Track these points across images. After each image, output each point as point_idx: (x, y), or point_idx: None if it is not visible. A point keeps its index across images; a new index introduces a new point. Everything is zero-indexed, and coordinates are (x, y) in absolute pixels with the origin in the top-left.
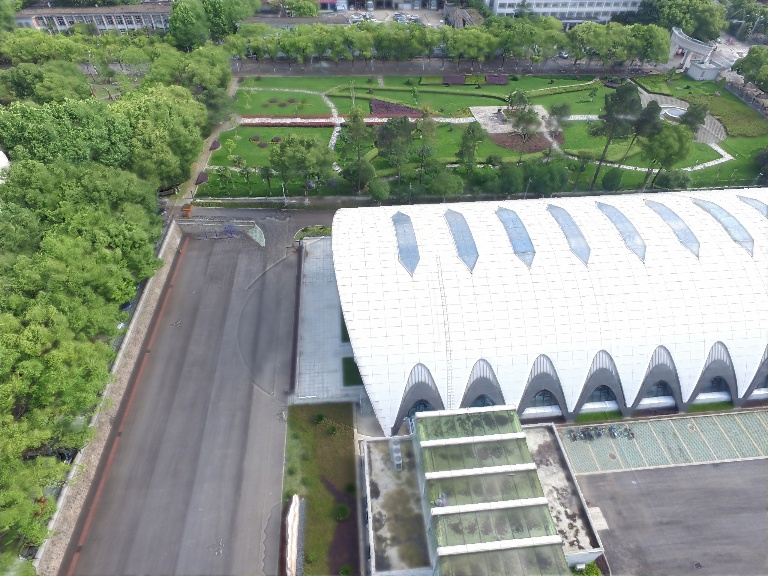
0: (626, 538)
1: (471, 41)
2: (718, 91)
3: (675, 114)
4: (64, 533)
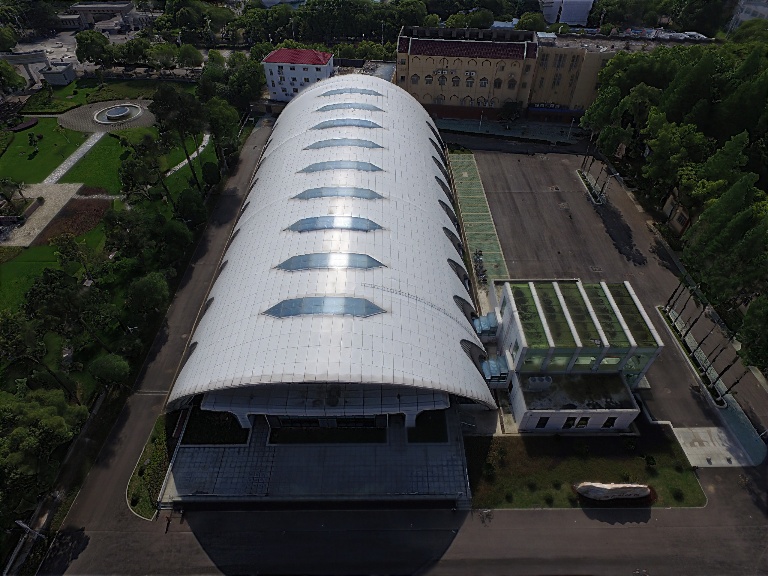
0: (551, 277)
1: None
2: (102, 82)
3: (118, 113)
4: None
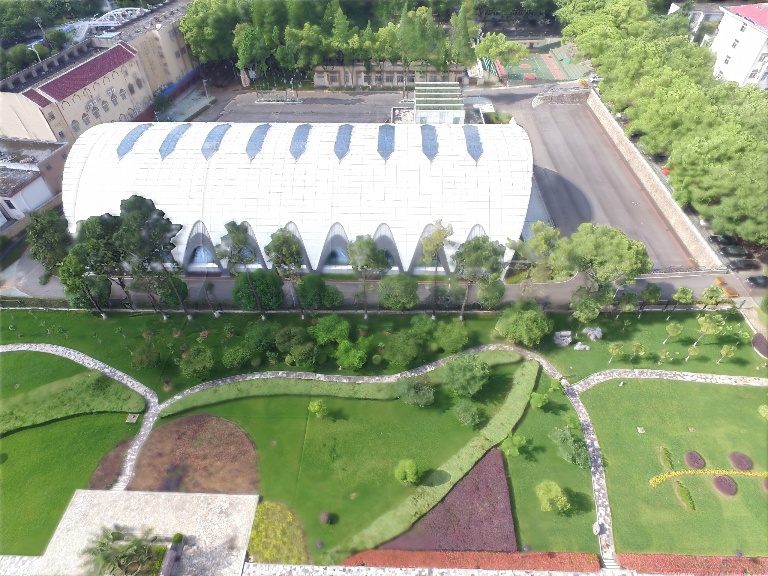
0: None
1: None
2: None
3: None
4: None
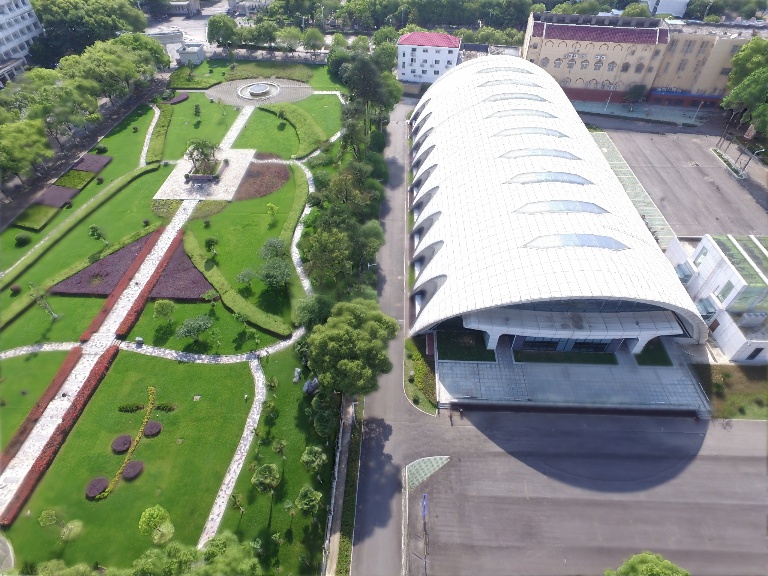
0: None
1: (22, 140)
2: (234, 62)
3: (260, 90)
4: None
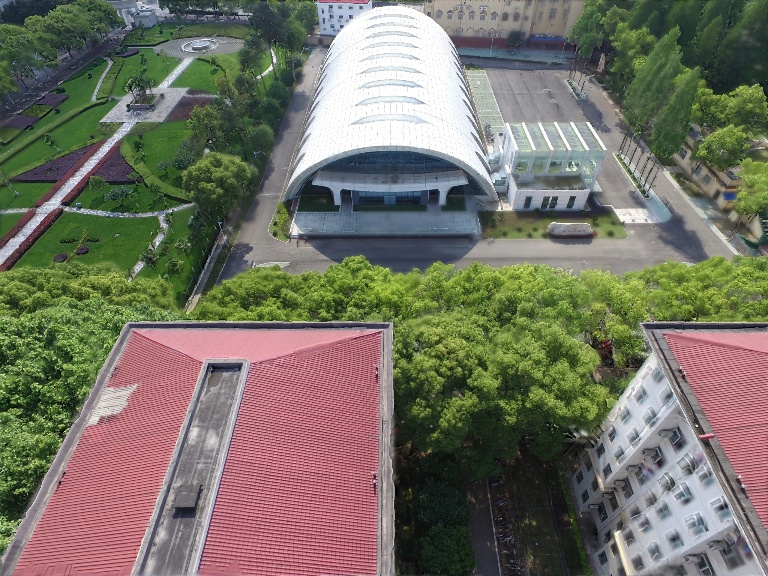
0: None
1: None
2: (181, 24)
3: (201, 45)
4: None
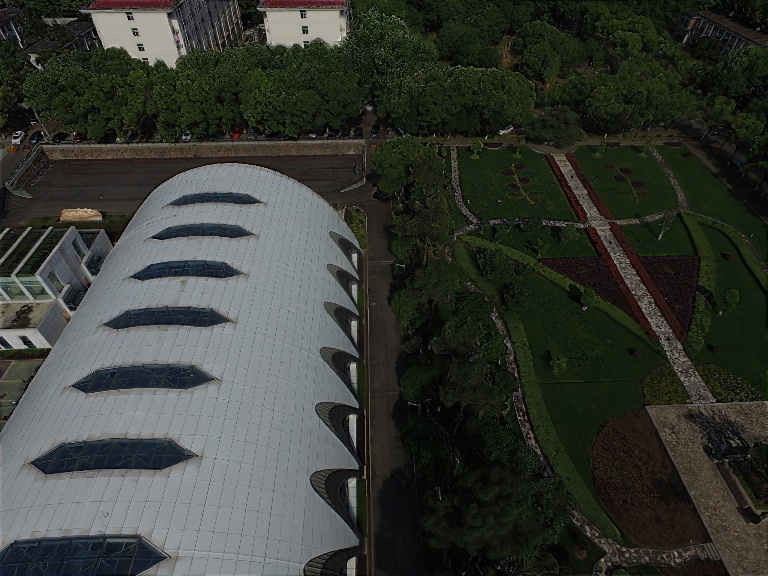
0: None
1: None
2: None
3: None
4: (137, 154)
